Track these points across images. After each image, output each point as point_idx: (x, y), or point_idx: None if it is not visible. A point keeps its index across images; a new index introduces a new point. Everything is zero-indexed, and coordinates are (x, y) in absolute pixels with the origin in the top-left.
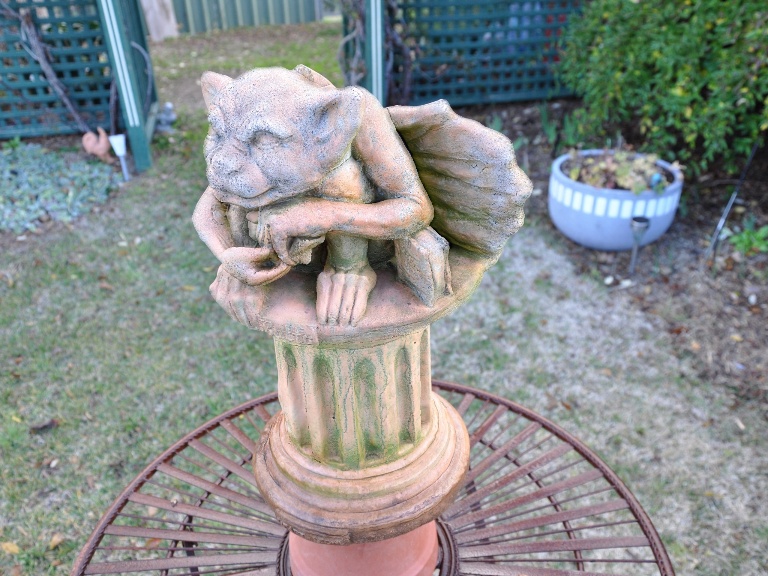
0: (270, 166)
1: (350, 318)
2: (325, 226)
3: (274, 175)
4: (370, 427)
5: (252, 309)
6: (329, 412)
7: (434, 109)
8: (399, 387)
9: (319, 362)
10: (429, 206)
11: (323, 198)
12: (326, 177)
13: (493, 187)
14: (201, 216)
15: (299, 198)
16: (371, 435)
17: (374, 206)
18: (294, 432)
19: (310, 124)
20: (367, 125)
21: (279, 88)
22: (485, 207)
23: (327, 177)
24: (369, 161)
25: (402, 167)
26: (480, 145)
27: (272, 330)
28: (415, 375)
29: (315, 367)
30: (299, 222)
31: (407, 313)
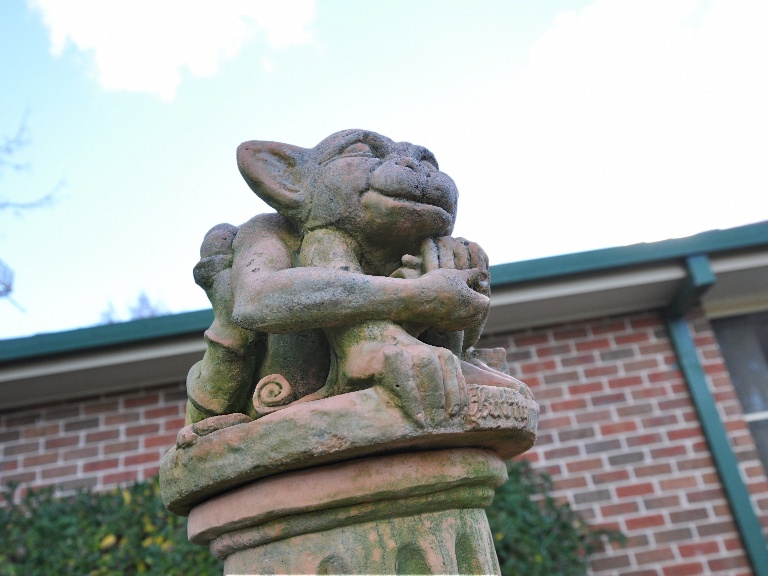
0: None
1: None
2: None
3: None
4: None
5: None
6: None
7: None
8: None
9: None
10: None
11: None
12: None
13: None
14: None
15: None
16: None
17: None
18: None
19: None
20: None
21: None
22: None
23: None
24: None
25: None
26: None
27: (488, 403)
28: None
29: None
30: None
31: None
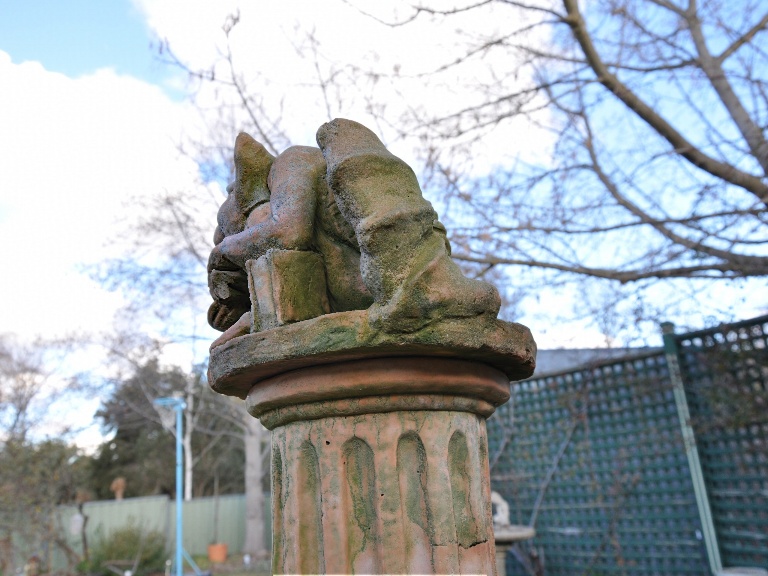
0: None
1: None
2: None
3: None
4: None
5: None
6: None
7: None
8: None
9: None
10: (289, 224)
11: None
12: None
13: None
14: None
15: None
16: None
17: None
18: None
19: None
20: None
21: None
22: None
23: None
24: None
25: None
26: None
27: None
28: (328, 503)
29: None
30: None
31: None
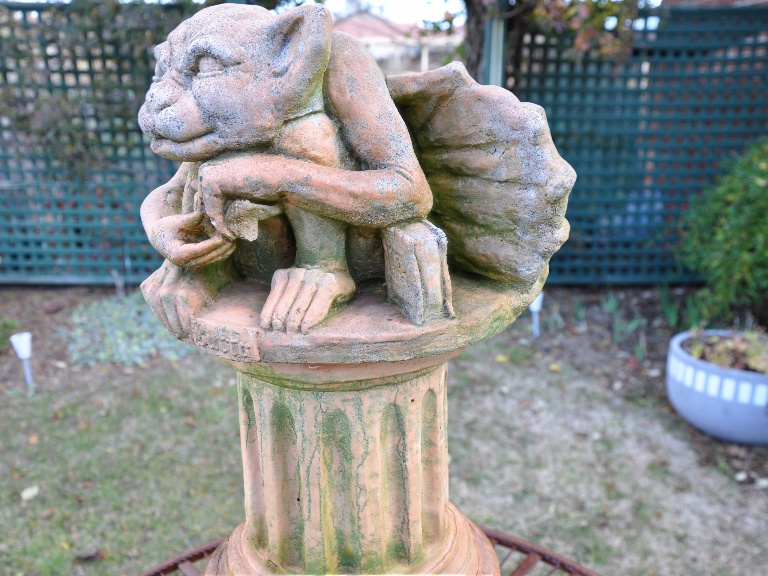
0: (206, 95)
1: (300, 322)
2: (271, 181)
3: (211, 108)
4: (345, 519)
5: (184, 306)
6: (293, 490)
7: (440, 73)
8: (389, 466)
9: (281, 410)
10: (424, 188)
11: (279, 155)
12: (285, 128)
13: (516, 177)
14: (153, 197)
15: (248, 152)
16: (345, 532)
17: (343, 170)
18: (251, 519)
19: (266, 54)
20: (344, 69)
21: (236, 15)
22: (508, 210)
23: (286, 129)
24: (346, 119)
25: (388, 129)
26: (497, 116)
27: (205, 336)
28: (412, 450)
29: (275, 417)
30: (237, 172)
31: (383, 328)
